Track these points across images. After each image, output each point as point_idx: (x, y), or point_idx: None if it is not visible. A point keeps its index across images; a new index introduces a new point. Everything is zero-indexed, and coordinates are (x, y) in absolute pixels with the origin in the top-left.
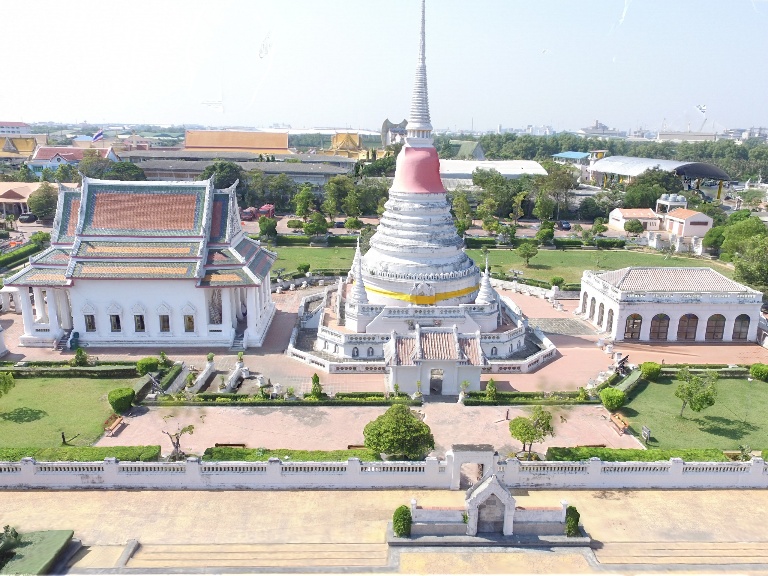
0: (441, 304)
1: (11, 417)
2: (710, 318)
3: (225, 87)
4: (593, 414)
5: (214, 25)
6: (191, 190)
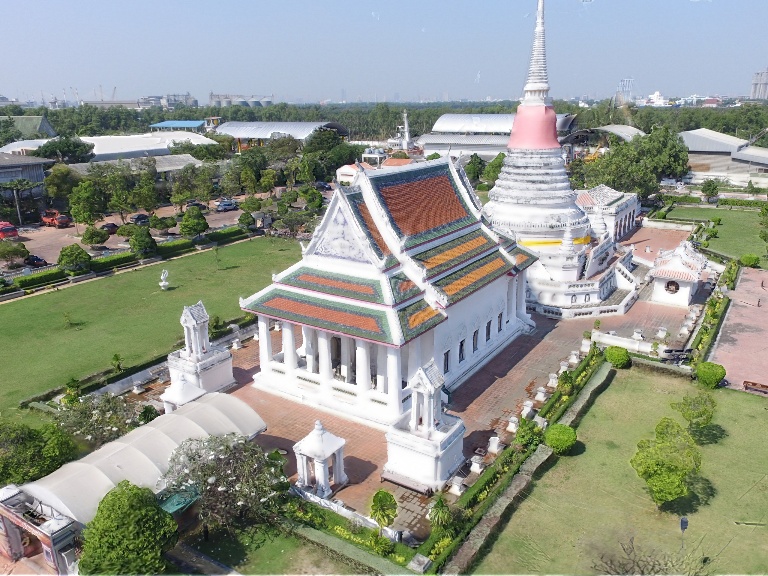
0: None
1: (709, 439)
2: None
3: None
4: (758, 271)
5: None
6: (441, 170)
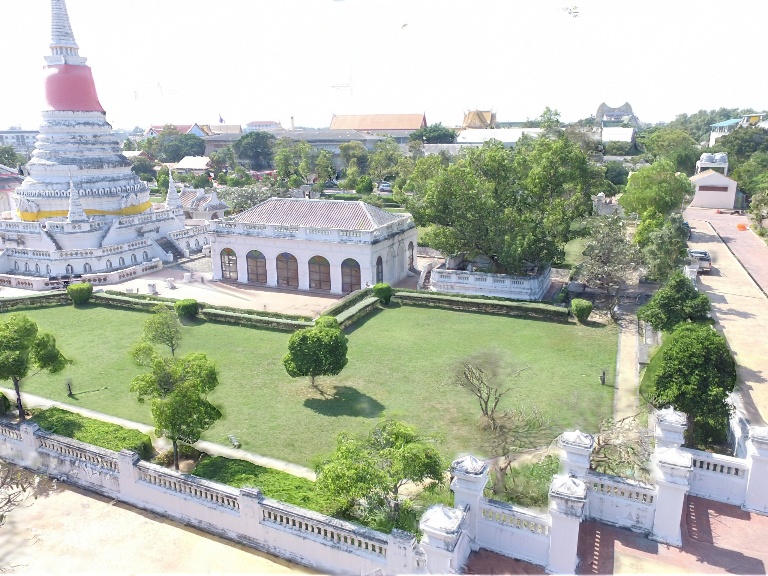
0: (44, 222)
1: None
2: (311, 260)
3: (353, 70)
4: None
5: (345, 11)
6: None
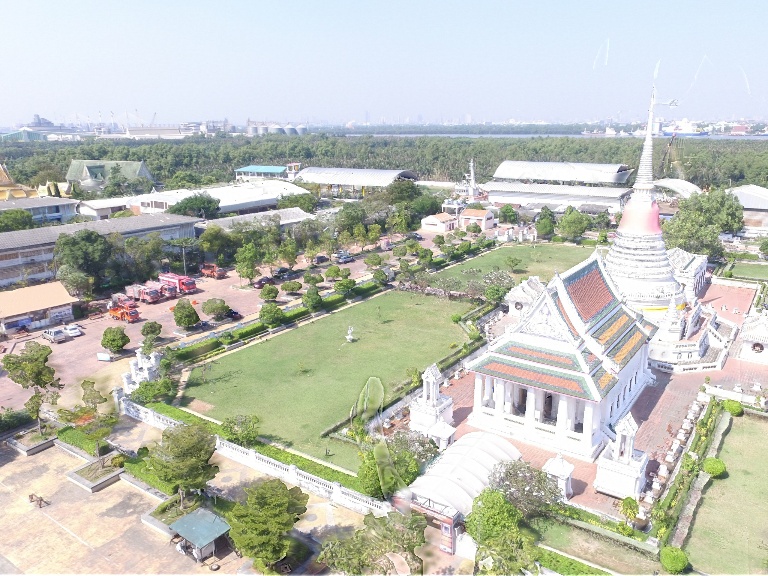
0: None
1: None
2: None
3: None
4: None
5: None
6: None
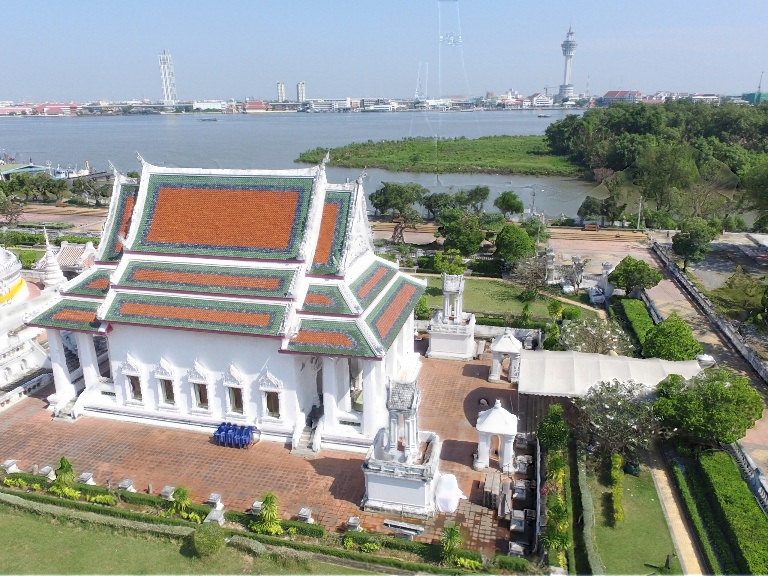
0: None
1: None
2: None
3: None
4: None
5: None
6: None
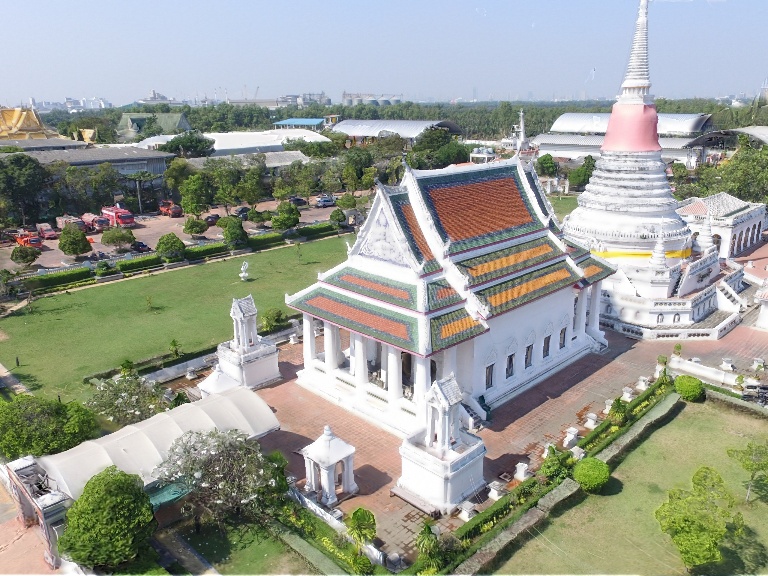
0: None
1: None
2: None
3: None
4: None
5: None
6: (506, 172)
